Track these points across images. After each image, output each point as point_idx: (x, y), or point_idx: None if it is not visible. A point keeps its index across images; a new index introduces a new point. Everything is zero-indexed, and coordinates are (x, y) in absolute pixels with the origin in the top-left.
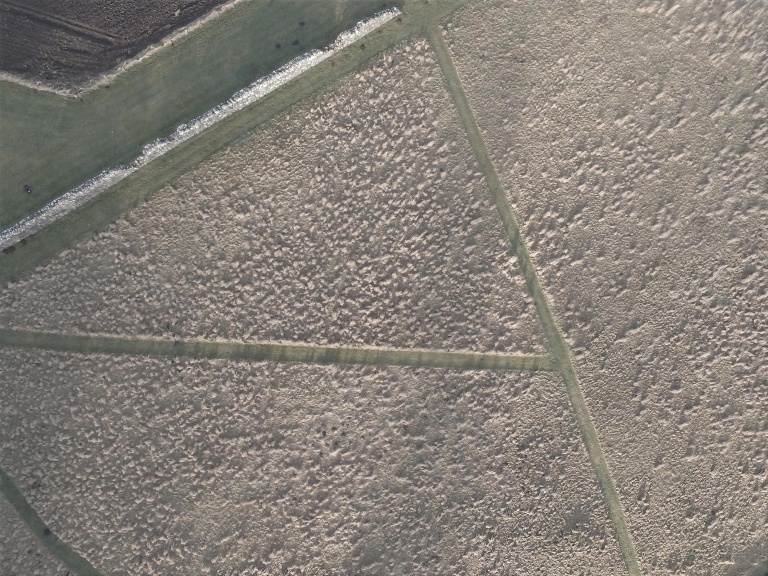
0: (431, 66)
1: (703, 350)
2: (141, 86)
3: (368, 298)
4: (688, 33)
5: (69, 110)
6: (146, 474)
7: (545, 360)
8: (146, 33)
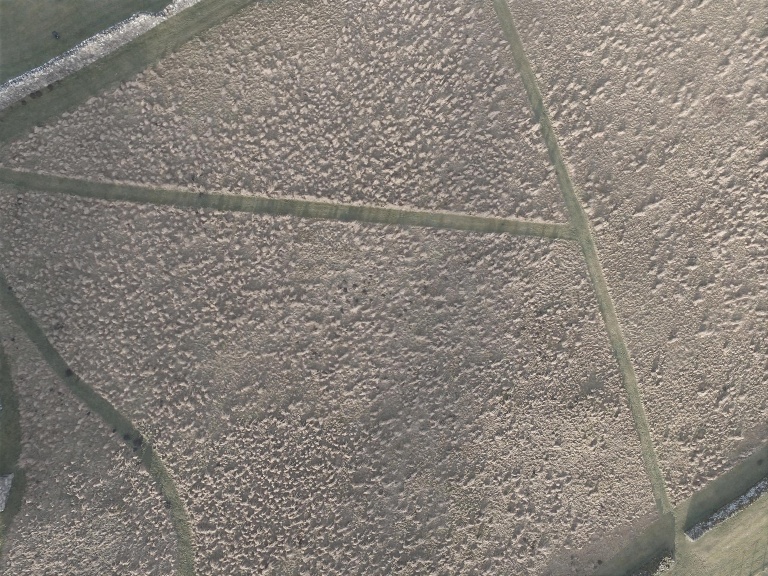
0: None
1: (719, 228)
2: None
3: (392, 158)
4: None
5: None
6: (168, 321)
7: (565, 229)
8: None
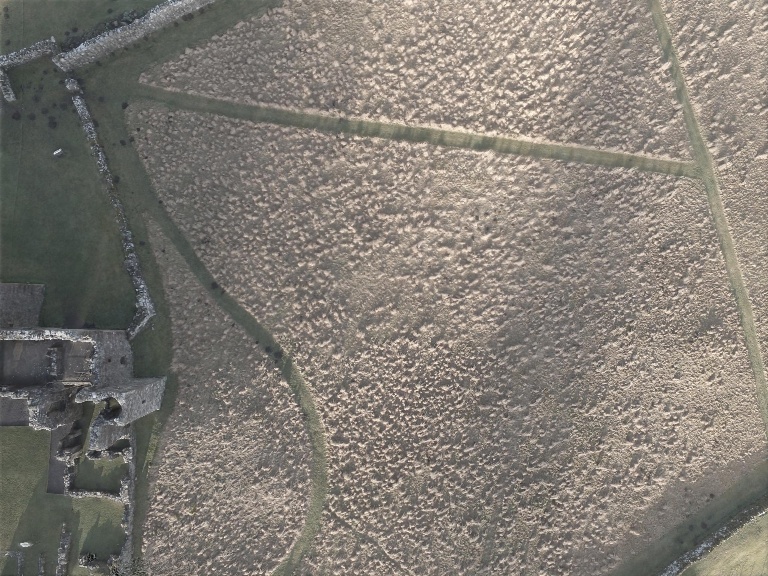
0: None
1: None
2: None
3: (526, 91)
4: None
5: None
6: (308, 240)
7: (690, 167)
8: None
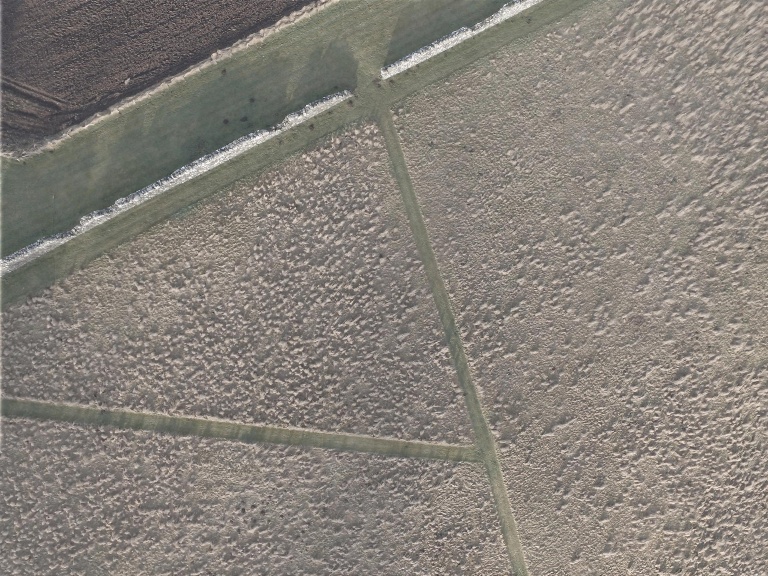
0: (379, 151)
1: (629, 449)
2: (85, 153)
3: (297, 379)
4: (641, 132)
5: (11, 172)
6: (62, 540)
7: (470, 451)
8: (94, 100)
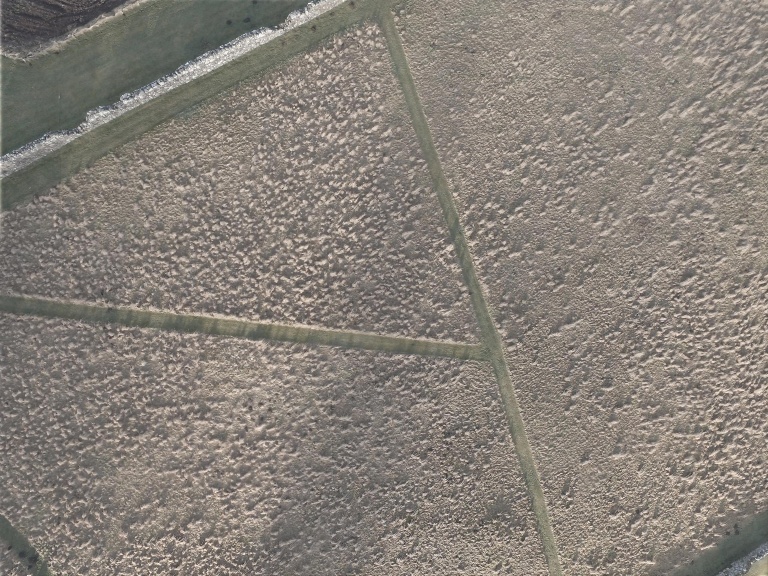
0: (381, 51)
1: (637, 349)
2: (90, 54)
3: (303, 277)
4: (641, 34)
5: (17, 73)
6: (70, 437)
7: (476, 349)
8: (99, 2)
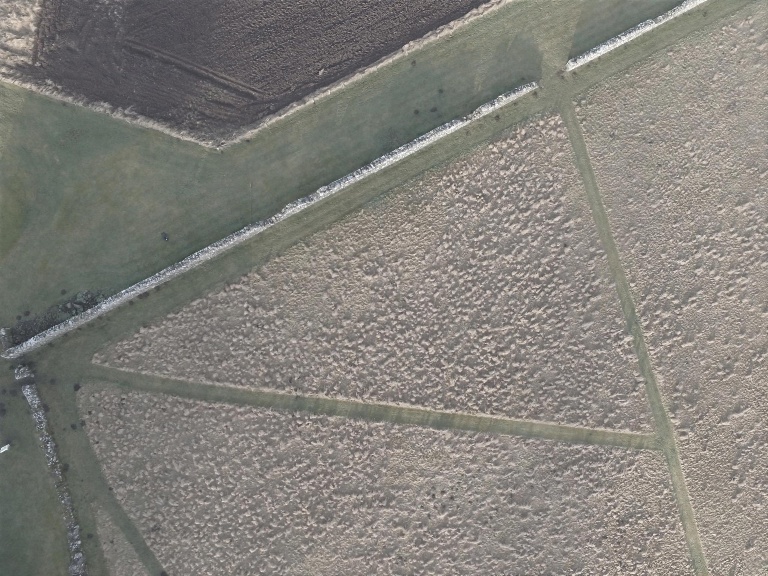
0: (562, 141)
1: None
2: (281, 142)
3: (486, 367)
4: None
5: (209, 161)
6: (261, 524)
7: (651, 439)
8: (289, 90)
